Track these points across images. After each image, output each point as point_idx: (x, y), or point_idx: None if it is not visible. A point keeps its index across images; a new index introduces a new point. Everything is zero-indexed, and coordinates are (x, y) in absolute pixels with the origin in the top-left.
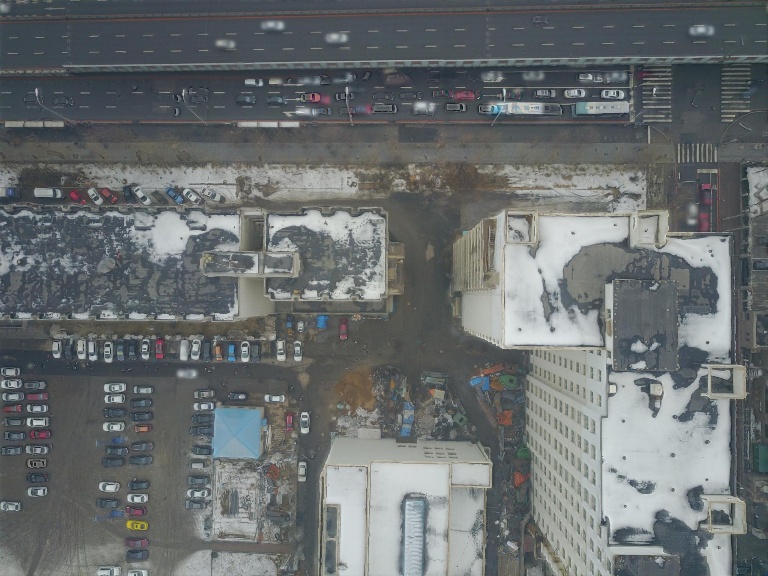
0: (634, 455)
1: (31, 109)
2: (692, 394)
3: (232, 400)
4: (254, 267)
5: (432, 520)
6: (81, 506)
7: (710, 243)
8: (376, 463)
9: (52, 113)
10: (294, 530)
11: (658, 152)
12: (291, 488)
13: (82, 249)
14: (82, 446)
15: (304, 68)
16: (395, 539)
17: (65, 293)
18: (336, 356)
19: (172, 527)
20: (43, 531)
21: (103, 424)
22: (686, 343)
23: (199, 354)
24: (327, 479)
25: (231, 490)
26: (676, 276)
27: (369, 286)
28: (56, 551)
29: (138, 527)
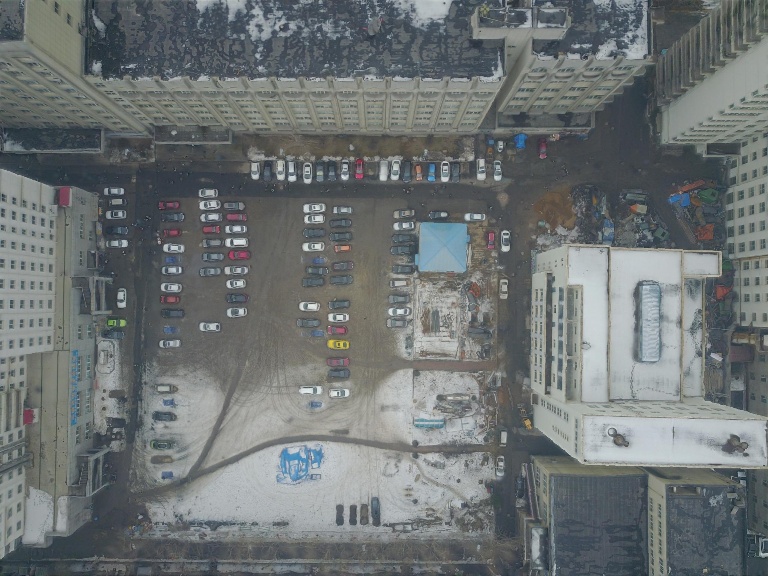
0: None
1: None
2: None
3: (432, 219)
4: (527, 22)
5: (664, 307)
6: (280, 327)
7: None
8: None
9: None
10: (495, 348)
11: None
12: (492, 306)
13: (344, 15)
14: (281, 267)
15: None
16: (628, 326)
17: (328, 58)
18: (534, 176)
19: (373, 347)
20: (242, 352)
21: (303, 244)
22: None
23: (399, 174)
24: (569, 260)
25: (432, 309)
26: None
27: (631, 49)
28: (255, 372)
29: (341, 345)
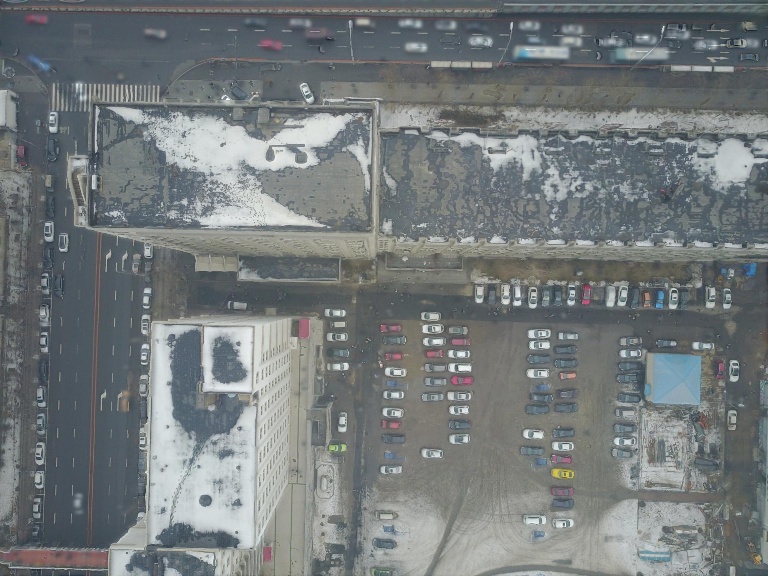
0: None
1: (448, 50)
2: None
3: (659, 347)
4: None
5: None
6: (503, 454)
7: None
8: None
9: (471, 54)
10: (722, 479)
11: None
12: (719, 437)
13: (642, 176)
14: (504, 393)
15: (747, 11)
16: None
17: (624, 220)
18: (763, 304)
19: (597, 476)
20: (464, 479)
21: (528, 370)
22: None
23: (626, 300)
24: None
25: (657, 438)
26: None
27: None
28: (477, 500)
29: (567, 475)
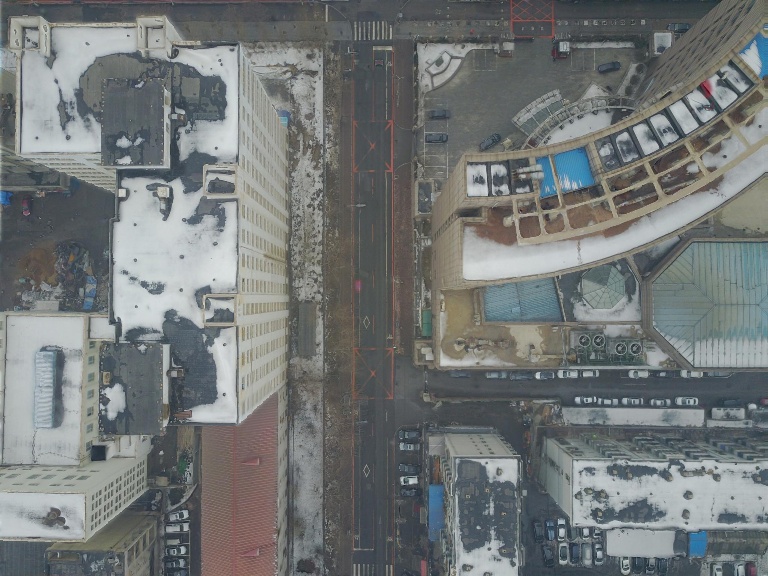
0: (144, 257)
1: None
2: (201, 198)
3: None
4: None
5: (68, 372)
6: None
7: (220, 53)
8: (12, 317)
9: None
10: None
11: (335, 30)
12: None
13: None
14: None
15: None
16: (31, 391)
17: None
18: (21, 232)
19: None
20: None
21: None
22: (196, 149)
23: None
24: None
25: None
26: (187, 85)
27: None
28: None
29: None
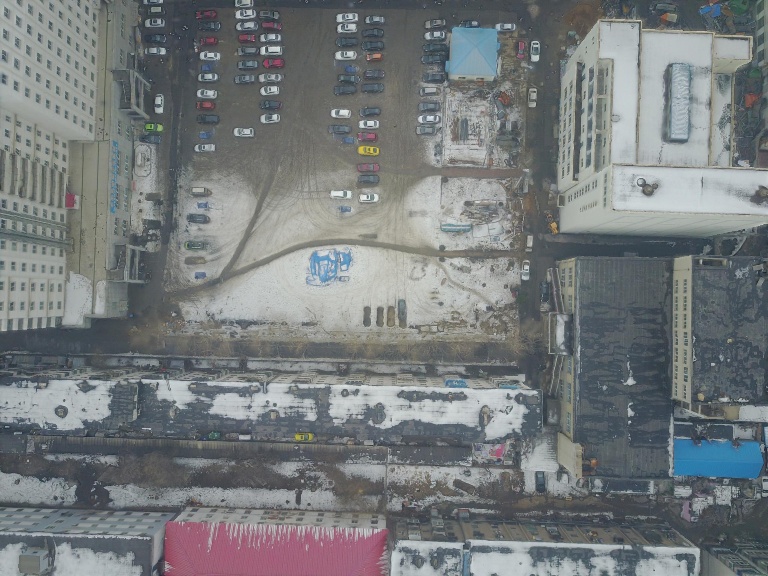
0: None
1: None
2: None
3: None
4: None
5: (694, 89)
6: (312, 134)
7: None
8: None
9: None
10: (523, 156)
11: None
12: (520, 115)
13: None
14: (313, 76)
15: None
16: (657, 107)
17: None
18: None
19: (402, 154)
20: (275, 158)
21: (336, 53)
22: None
23: None
24: (600, 34)
25: (461, 118)
26: None
27: None
28: (287, 177)
29: (371, 150)
